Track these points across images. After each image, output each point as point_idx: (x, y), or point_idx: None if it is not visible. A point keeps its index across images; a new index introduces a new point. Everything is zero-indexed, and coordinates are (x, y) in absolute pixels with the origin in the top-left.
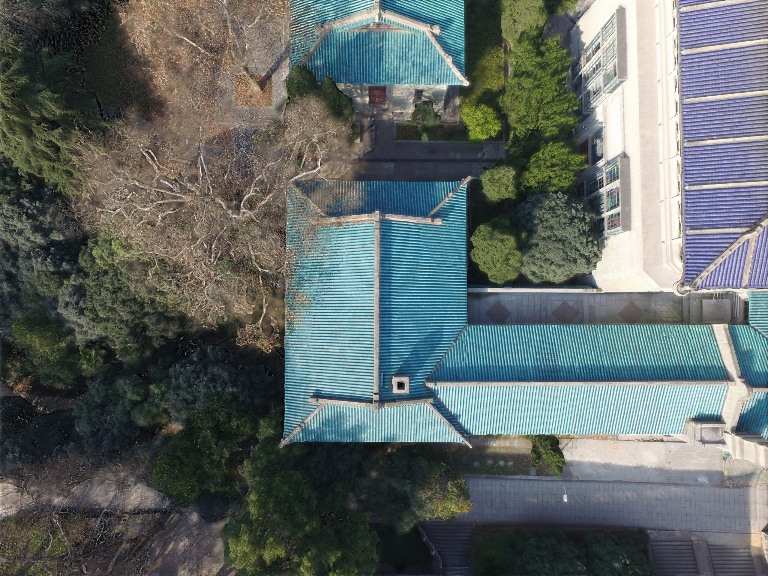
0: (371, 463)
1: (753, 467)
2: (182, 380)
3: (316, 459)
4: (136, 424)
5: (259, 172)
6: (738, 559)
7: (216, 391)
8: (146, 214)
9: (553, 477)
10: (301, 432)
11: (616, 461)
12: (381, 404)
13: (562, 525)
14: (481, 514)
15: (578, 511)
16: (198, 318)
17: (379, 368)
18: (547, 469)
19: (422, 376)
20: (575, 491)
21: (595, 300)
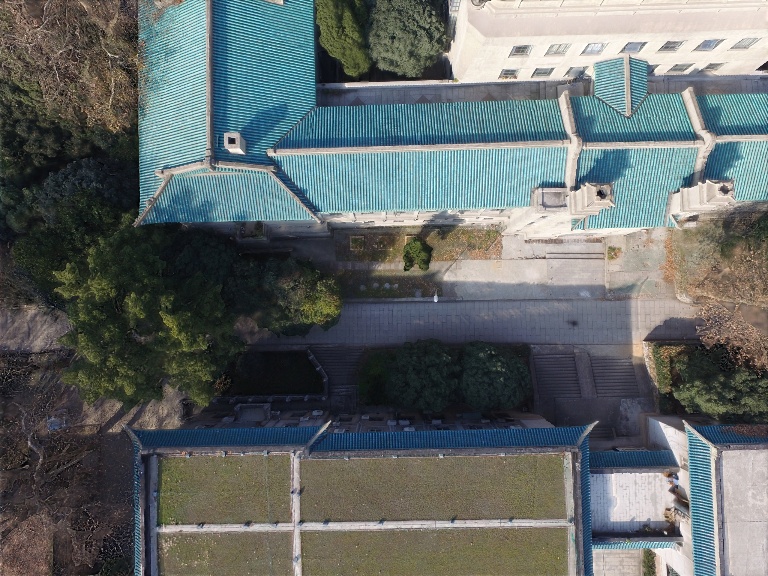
0: (242, 266)
1: (634, 279)
2: (50, 179)
3: (182, 254)
4: (14, 232)
5: (137, 1)
6: (619, 368)
7: (81, 187)
8: (5, 13)
9: (438, 298)
10: (154, 211)
11: (499, 279)
12: (214, 160)
13: (448, 344)
14: (370, 338)
15: (463, 330)
16: (74, 134)
17: (214, 129)
18: (432, 290)
19: (264, 146)
20: (460, 311)
21: (453, 93)
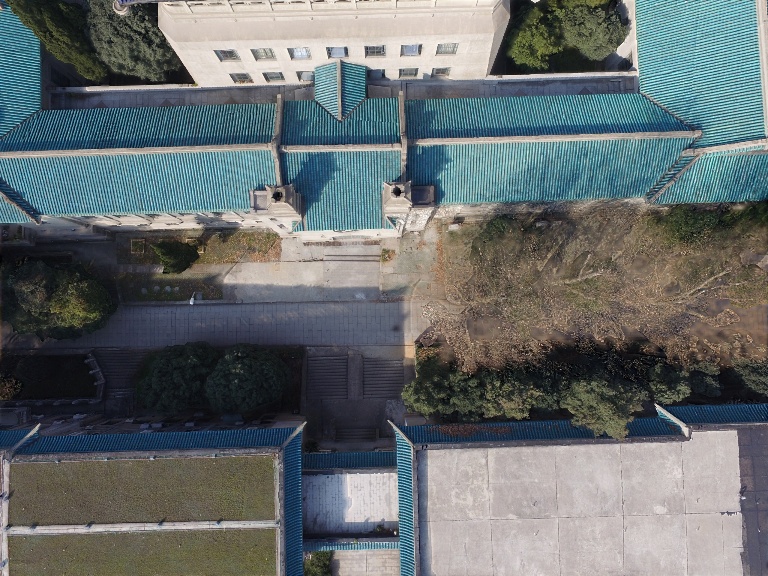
0: None
1: (407, 281)
2: None
3: None
4: None
5: None
6: (390, 369)
7: None
8: None
9: (218, 300)
10: None
11: (277, 282)
12: None
13: (228, 347)
14: (153, 341)
15: (243, 333)
16: None
17: None
18: (212, 293)
19: None
20: (241, 314)
21: (196, 97)
